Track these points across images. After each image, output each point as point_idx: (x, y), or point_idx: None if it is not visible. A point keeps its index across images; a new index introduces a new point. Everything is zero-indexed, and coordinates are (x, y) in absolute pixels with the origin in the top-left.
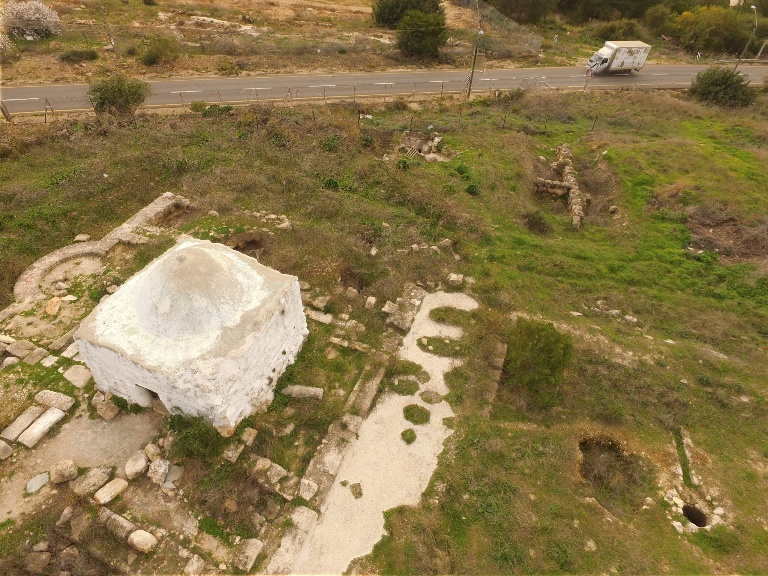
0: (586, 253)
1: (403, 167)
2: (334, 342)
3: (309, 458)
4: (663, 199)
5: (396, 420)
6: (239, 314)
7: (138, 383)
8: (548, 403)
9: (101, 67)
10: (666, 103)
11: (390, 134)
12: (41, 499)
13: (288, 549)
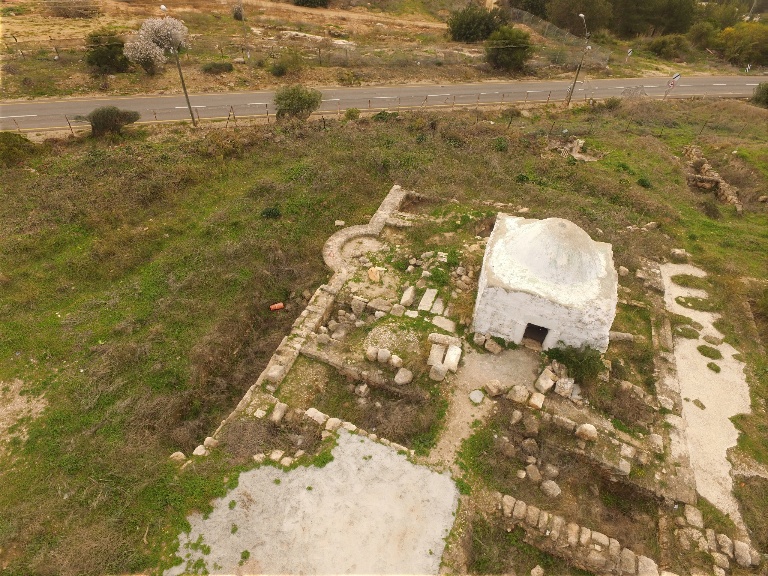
0: None
1: None
2: None
3: (653, 382)
4: None
5: (697, 356)
6: (603, 268)
7: (534, 322)
8: None
9: (239, 78)
10: (752, 110)
11: (533, 137)
12: (489, 407)
13: (679, 442)
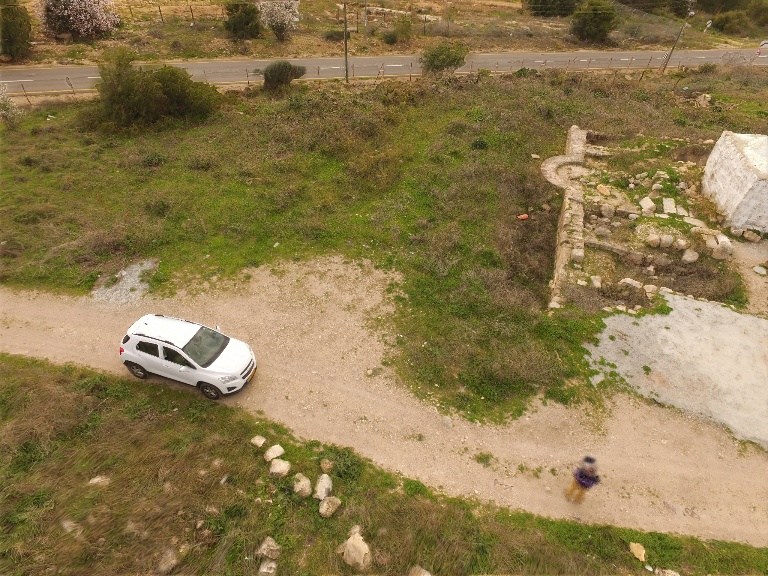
0: None
1: None
2: None
3: None
4: None
5: None
6: None
7: None
8: None
9: (357, 45)
10: None
11: None
12: None
13: None
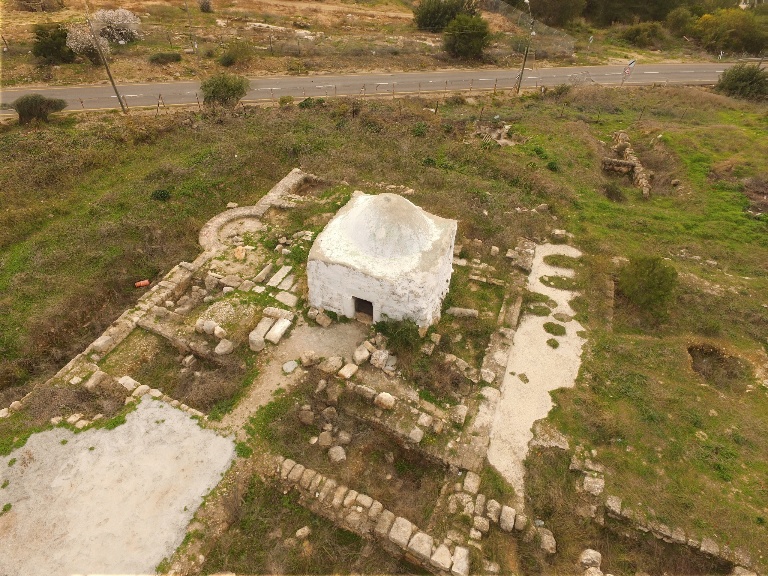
0: (662, 215)
1: (488, 148)
2: (474, 279)
3: (482, 356)
4: (720, 173)
5: (539, 333)
6: (430, 243)
7: (356, 295)
8: (662, 317)
9: (186, 68)
10: (702, 96)
11: (462, 123)
12: (298, 376)
13: (486, 413)
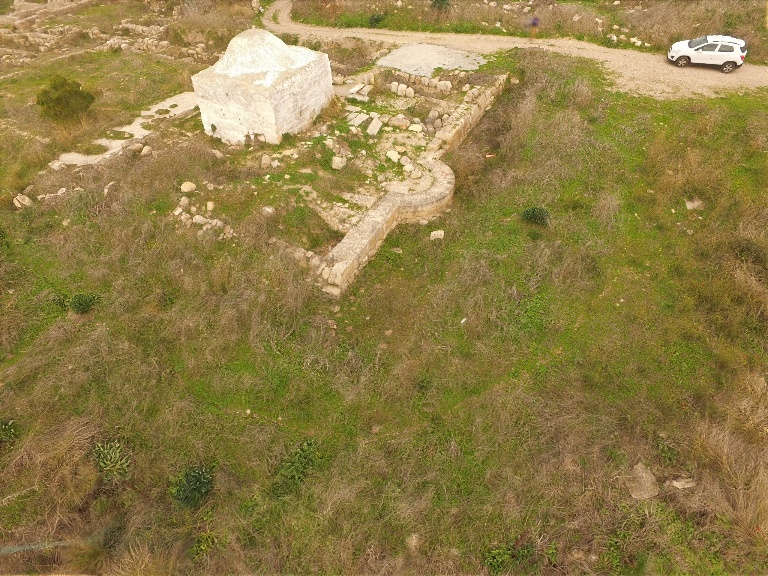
0: None
1: None
2: None
3: None
4: None
5: None
6: None
7: None
8: None
9: None
10: None
11: None
12: None
13: None
